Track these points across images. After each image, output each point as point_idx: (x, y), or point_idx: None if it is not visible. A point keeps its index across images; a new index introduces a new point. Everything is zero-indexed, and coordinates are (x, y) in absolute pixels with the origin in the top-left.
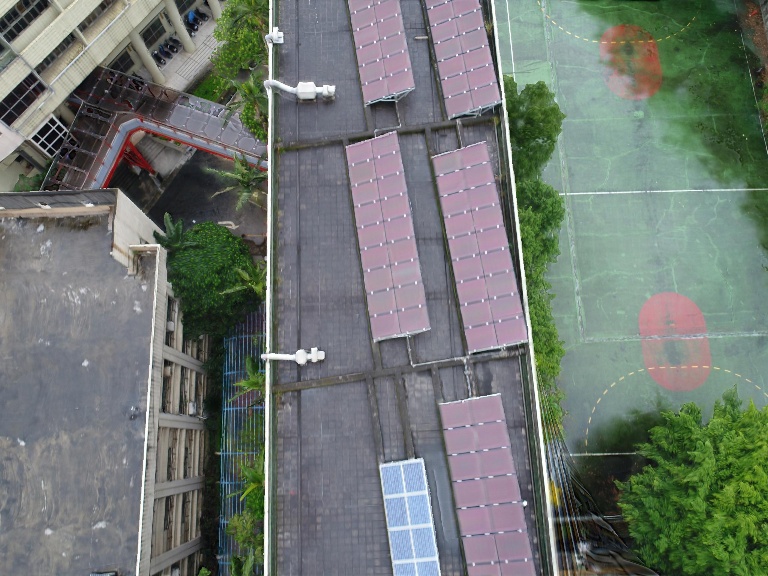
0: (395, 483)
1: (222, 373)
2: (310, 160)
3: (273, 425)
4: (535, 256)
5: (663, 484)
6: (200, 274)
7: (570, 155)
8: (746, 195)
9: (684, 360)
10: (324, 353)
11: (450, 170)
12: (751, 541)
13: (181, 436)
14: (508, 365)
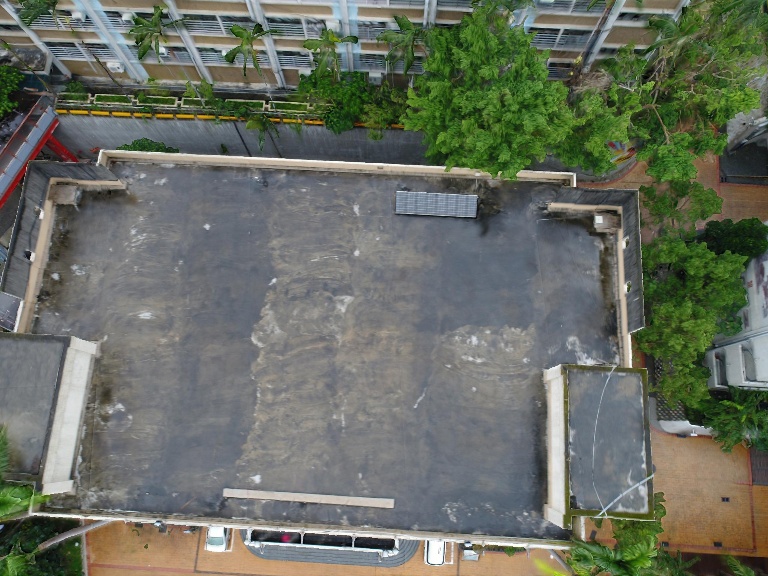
0: None
1: None
2: None
3: None
4: None
5: None
6: None
7: None
8: None
9: None
10: None
11: None
12: None
13: None
14: None
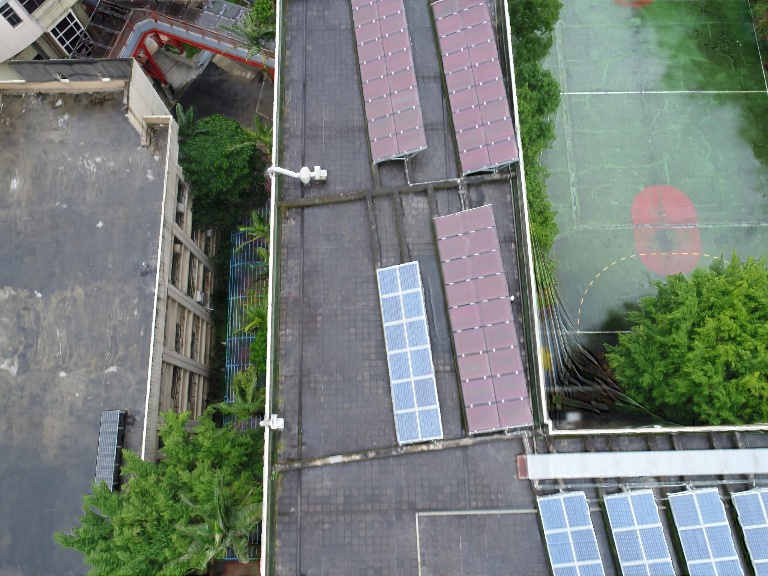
0: (391, 284)
1: (229, 266)
2: (316, 7)
3: (277, 236)
4: (531, 139)
5: (648, 330)
6: (210, 158)
7: (568, 58)
8: (739, 97)
9: (675, 247)
10: (326, 171)
11: (448, 13)
12: (729, 367)
13: (189, 319)
14: (500, 188)
